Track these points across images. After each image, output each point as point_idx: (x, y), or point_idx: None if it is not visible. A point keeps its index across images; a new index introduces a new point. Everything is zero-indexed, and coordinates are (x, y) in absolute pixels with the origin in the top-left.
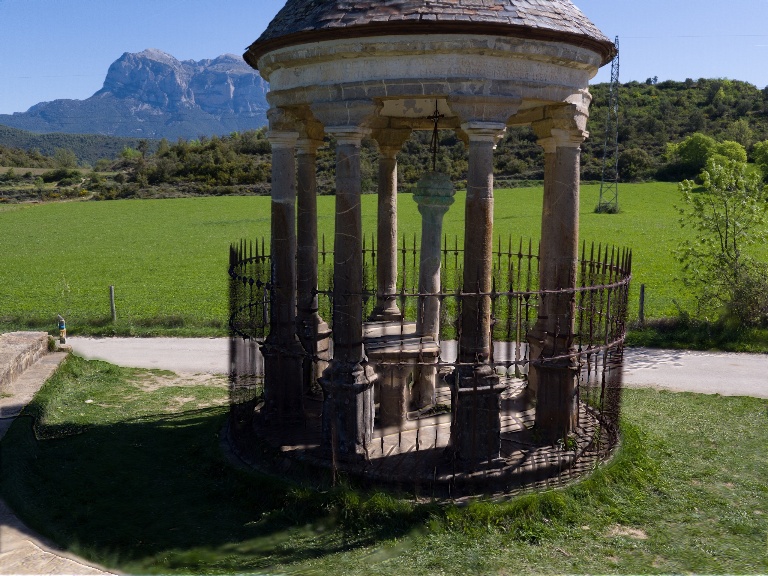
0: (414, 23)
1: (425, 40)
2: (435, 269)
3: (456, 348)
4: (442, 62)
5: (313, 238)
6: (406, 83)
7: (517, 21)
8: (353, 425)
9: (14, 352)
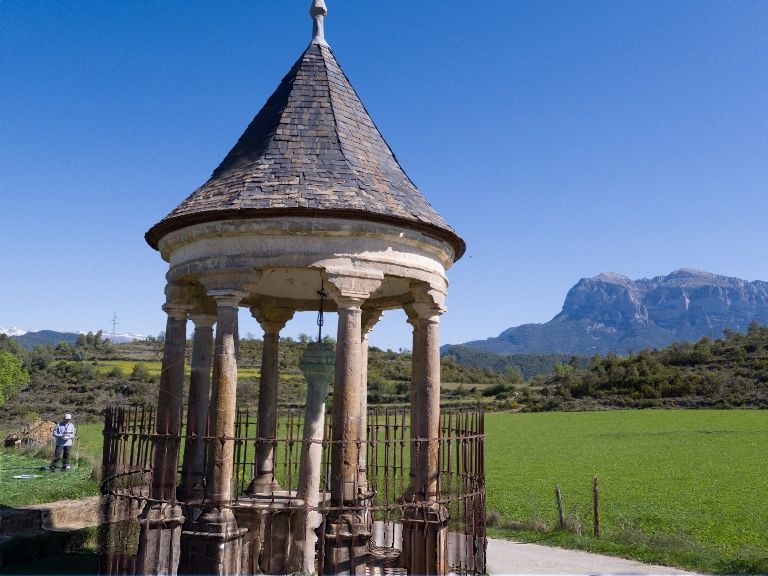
0: (174, 221)
1: (184, 232)
2: (311, 433)
3: (540, 554)
4: (198, 247)
5: (268, 406)
6: (182, 266)
7: (226, 207)
8: (142, 558)
9: (127, 493)
